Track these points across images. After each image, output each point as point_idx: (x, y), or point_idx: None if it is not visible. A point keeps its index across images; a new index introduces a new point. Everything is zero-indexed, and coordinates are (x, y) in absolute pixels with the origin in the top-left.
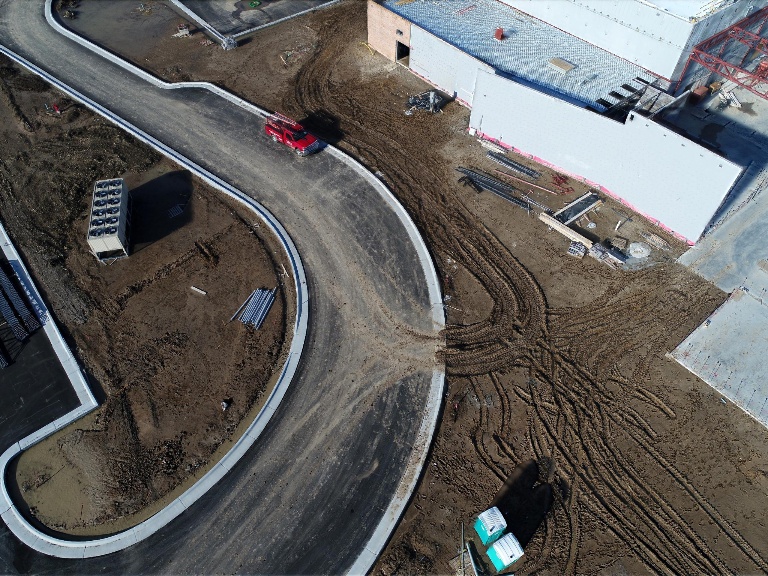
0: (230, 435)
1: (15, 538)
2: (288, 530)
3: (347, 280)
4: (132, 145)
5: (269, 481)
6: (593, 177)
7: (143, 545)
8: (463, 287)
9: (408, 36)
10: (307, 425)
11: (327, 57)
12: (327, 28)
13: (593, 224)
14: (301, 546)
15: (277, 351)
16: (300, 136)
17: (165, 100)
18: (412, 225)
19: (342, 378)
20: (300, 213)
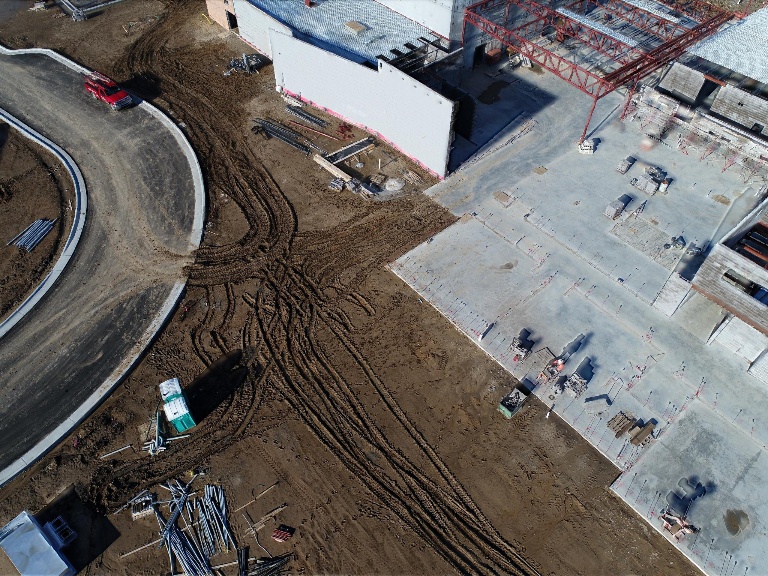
0: None
1: None
2: (5, 406)
3: (123, 212)
4: None
5: (1, 370)
6: (371, 124)
7: None
8: (227, 216)
9: (232, 5)
10: (49, 326)
11: (168, 27)
12: (177, 2)
13: (360, 164)
14: (13, 418)
15: (42, 269)
16: (110, 91)
17: (4, 64)
18: (197, 166)
19: (93, 289)
20: (99, 158)
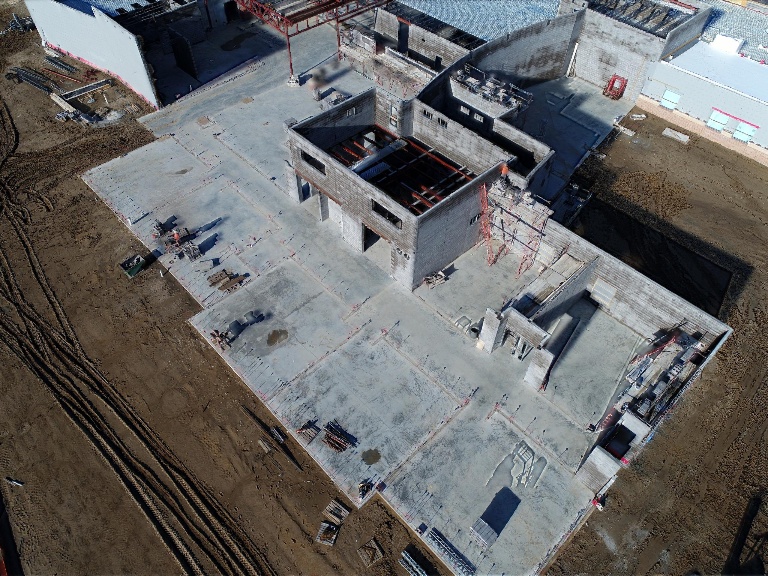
0: None
1: None
2: None
3: None
4: None
5: None
6: (111, 68)
7: None
8: None
9: None
10: None
11: None
12: None
13: (92, 100)
14: None
15: None
16: None
17: None
18: None
19: None
20: None
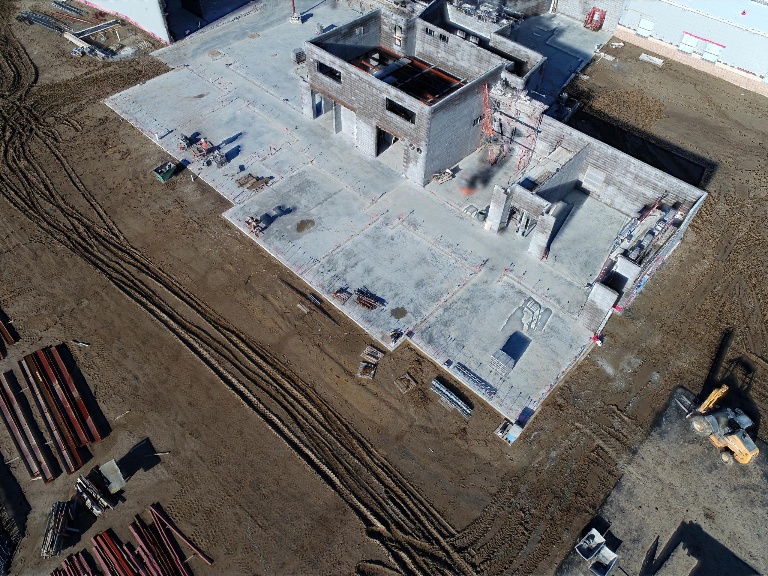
0: None
1: None
2: None
3: None
4: None
5: None
6: (119, 9)
7: None
8: None
9: None
10: None
11: None
12: None
13: (104, 38)
14: None
15: None
16: None
17: None
18: None
19: None
20: None
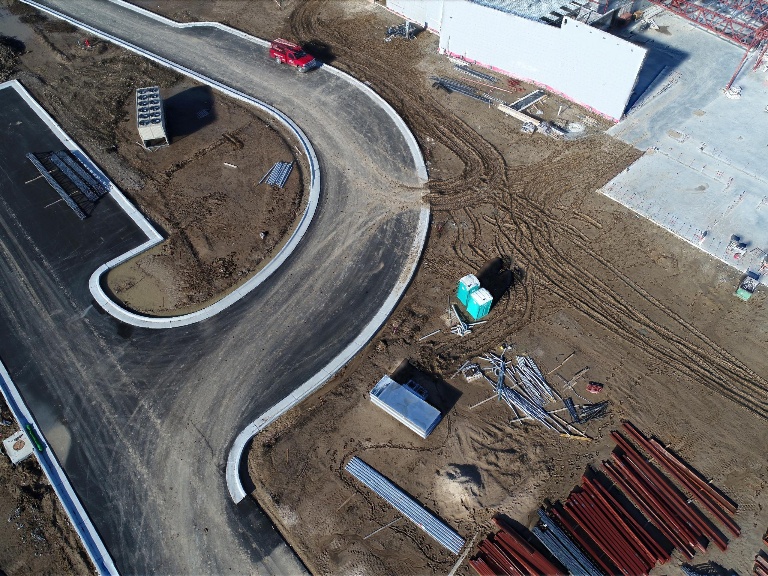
0: (269, 253)
1: (116, 319)
2: (321, 305)
3: (349, 154)
4: (158, 69)
5: (303, 278)
6: (540, 78)
7: (214, 319)
8: (440, 156)
9: None
10: (327, 245)
11: (315, 1)
12: None
13: (541, 111)
14: (331, 313)
15: (299, 201)
16: (301, 54)
17: (180, 36)
18: (397, 116)
19: (351, 215)
20: (306, 112)
